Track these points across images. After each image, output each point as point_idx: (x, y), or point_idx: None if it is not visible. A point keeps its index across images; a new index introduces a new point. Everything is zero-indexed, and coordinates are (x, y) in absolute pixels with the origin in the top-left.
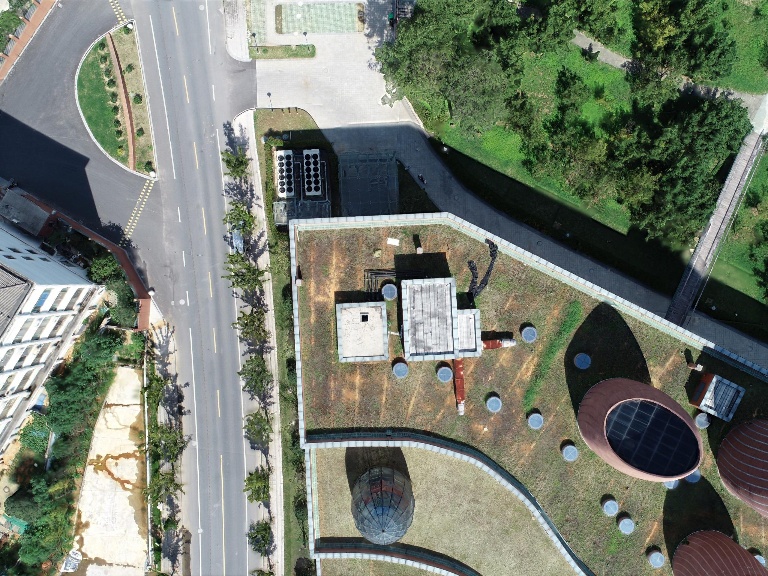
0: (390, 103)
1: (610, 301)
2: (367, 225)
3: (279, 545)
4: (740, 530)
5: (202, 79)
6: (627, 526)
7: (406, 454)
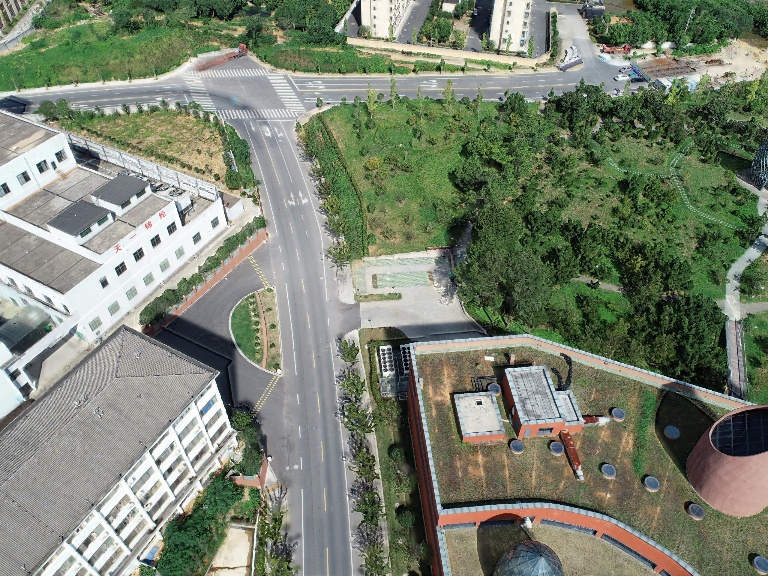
0: (465, 300)
1: (674, 389)
2: (467, 349)
3: None
4: None
5: (320, 315)
6: None
7: None
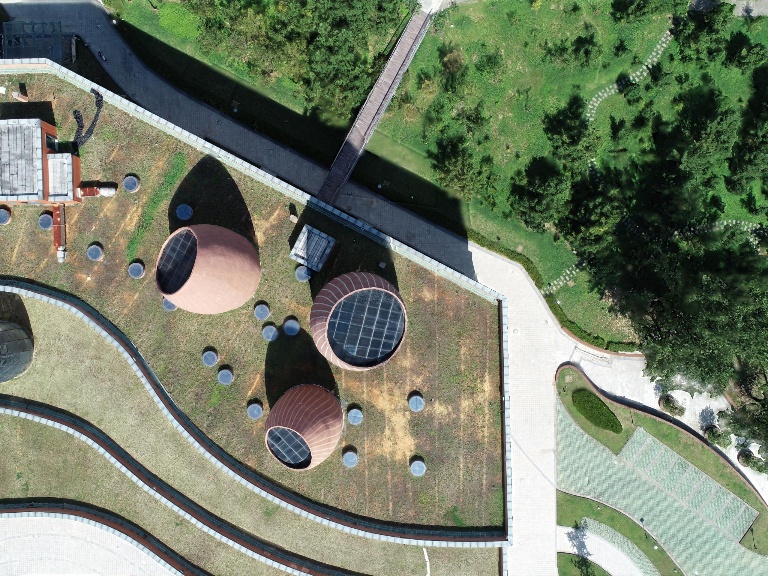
0: None
1: (214, 153)
2: None
3: None
4: (342, 385)
5: None
6: (225, 377)
7: (29, 309)
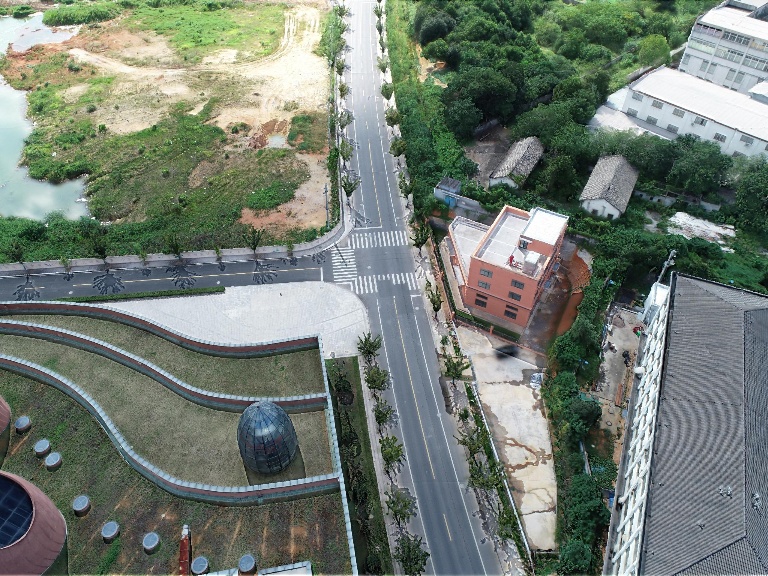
0: None
1: None
2: None
3: (370, 412)
4: None
5: None
6: (42, 446)
7: None
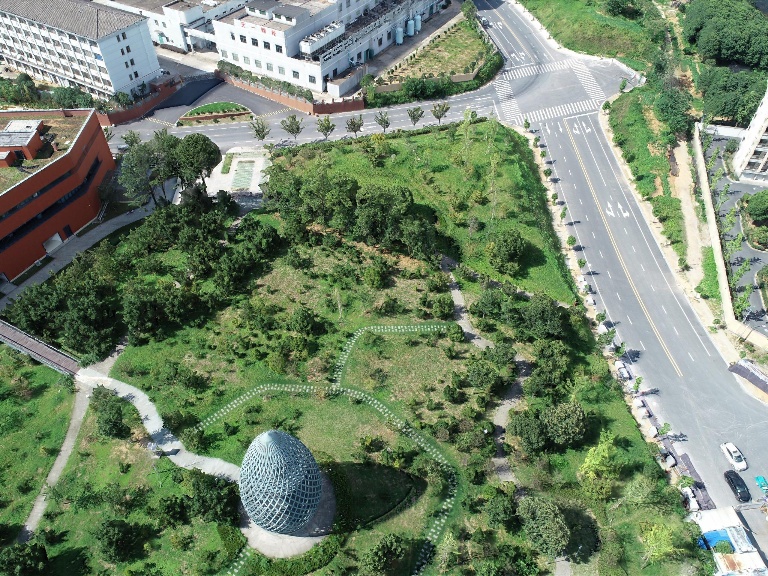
0: None
1: None
2: None
3: None
4: None
5: (222, 140)
6: None
7: None
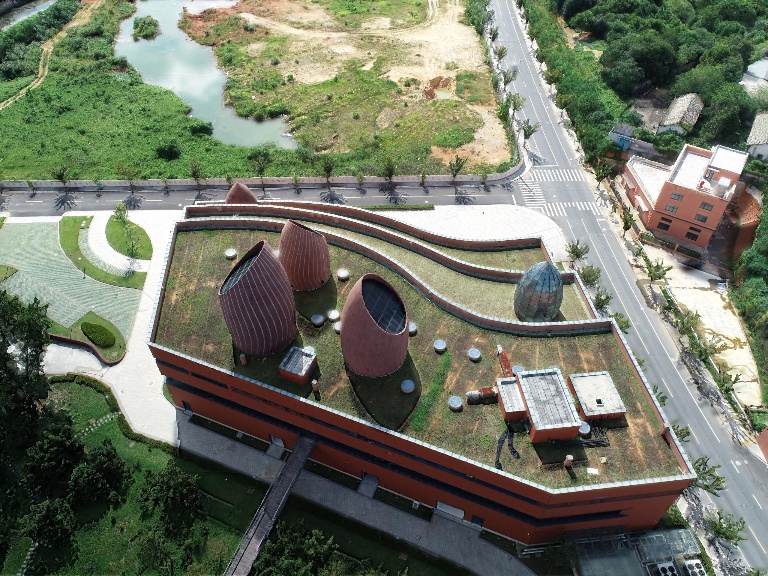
0: None
1: None
2: None
3: None
4: None
5: None
6: None
7: None
